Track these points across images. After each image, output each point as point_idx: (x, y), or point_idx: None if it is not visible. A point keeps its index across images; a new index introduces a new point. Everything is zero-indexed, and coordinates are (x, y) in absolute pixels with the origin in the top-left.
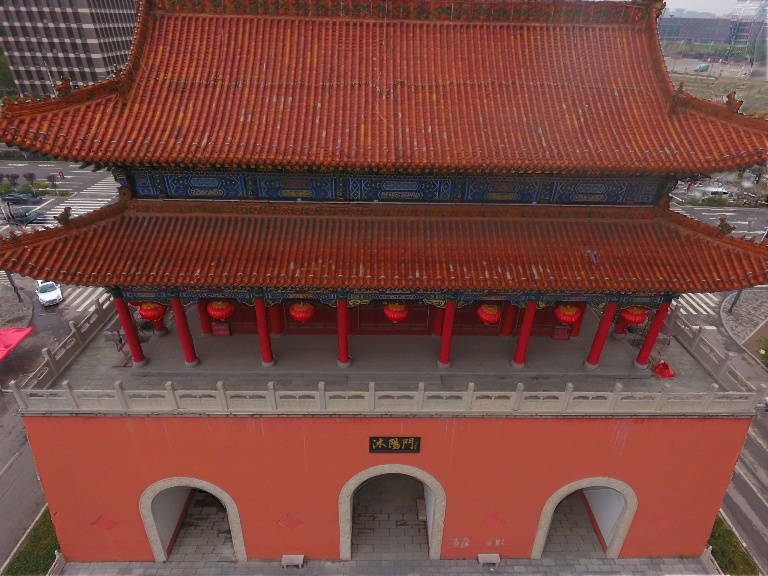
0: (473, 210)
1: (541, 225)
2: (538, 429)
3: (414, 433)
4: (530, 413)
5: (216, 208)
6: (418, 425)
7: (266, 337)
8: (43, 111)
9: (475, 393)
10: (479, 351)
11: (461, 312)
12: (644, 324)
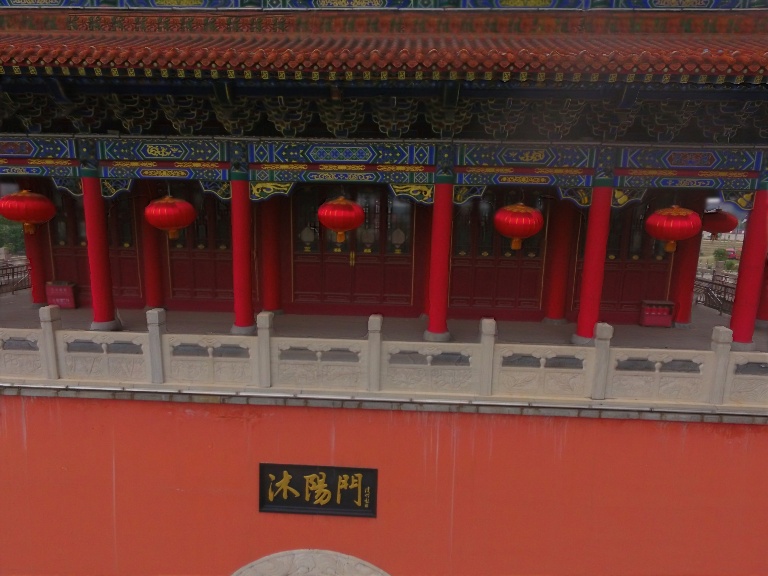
0: (475, 20)
1: (601, 41)
2: (659, 457)
3: (362, 457)
4: (635, 405)
5: (43, 20)
6: (371, 433)
7: (99, 263)
8: None
9: (499, 346)
10: (507, 332)
11: (470, 270)
12: None
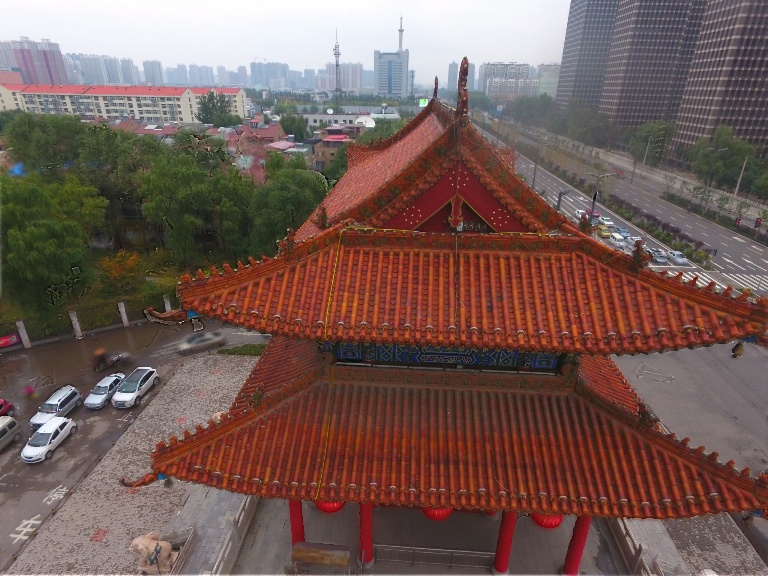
0: None
1: None
2: None
3: None
4: None
5: None
6: None
7: None
8: (363, 151)
9: None
10: None
11: None
12: None
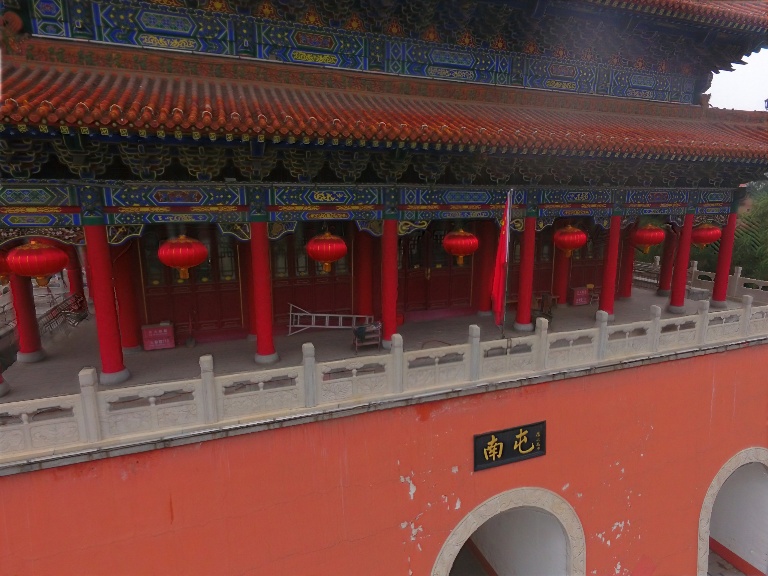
0: None
1: None
2: None
3: None
4: None
5: None
6: None
7: None
8: None
9: None
10: None
11: None
12: (40, 298)
